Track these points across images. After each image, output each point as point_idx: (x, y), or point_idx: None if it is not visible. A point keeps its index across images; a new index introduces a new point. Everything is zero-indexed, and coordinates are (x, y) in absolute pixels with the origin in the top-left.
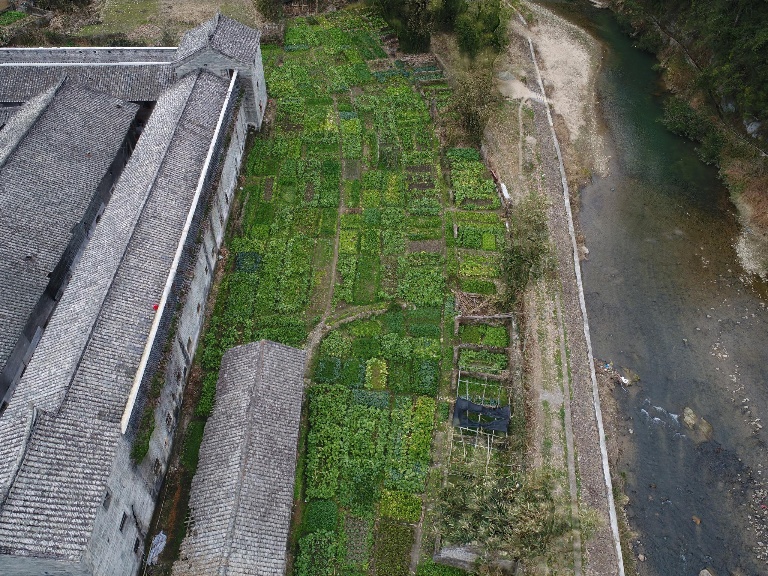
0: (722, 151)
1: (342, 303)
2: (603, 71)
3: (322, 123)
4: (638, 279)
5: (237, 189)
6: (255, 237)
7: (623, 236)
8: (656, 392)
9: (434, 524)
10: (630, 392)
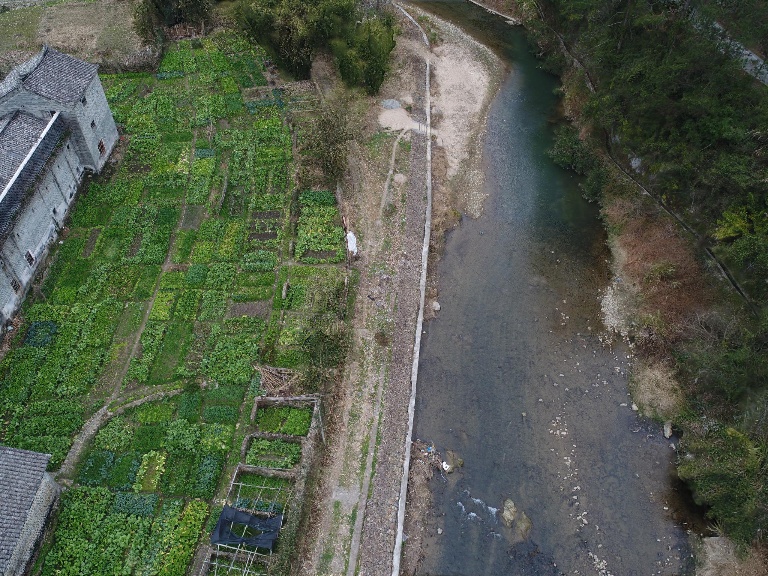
0: (605, 187)
1: (134, 382)
2: (501, 96)
3: (173, 163)
4: (487, 340)
5: (56, 243)
6: (58, 302)
7: (482, 288)
8: (479, 480)
9: None
10: (449, 481)
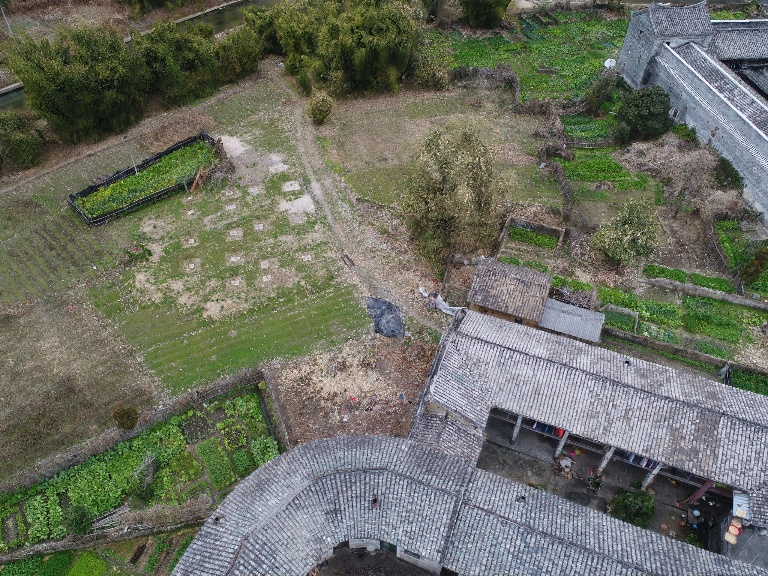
0: None
1: None
2: None
3: None
4: (674, 1)
5: None
6: None
7: (643, 1)
8: None
9: None
10: None
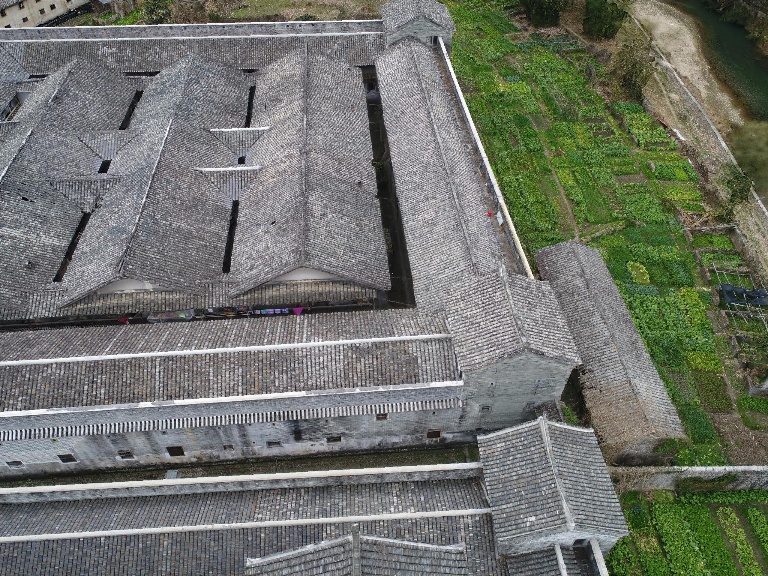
0: None
1: (585, 223)
2: (703, 41)
3: (494, 86)
4: None
5: None
6: None
7: None
8: None
9: (736, 372)
10: None
